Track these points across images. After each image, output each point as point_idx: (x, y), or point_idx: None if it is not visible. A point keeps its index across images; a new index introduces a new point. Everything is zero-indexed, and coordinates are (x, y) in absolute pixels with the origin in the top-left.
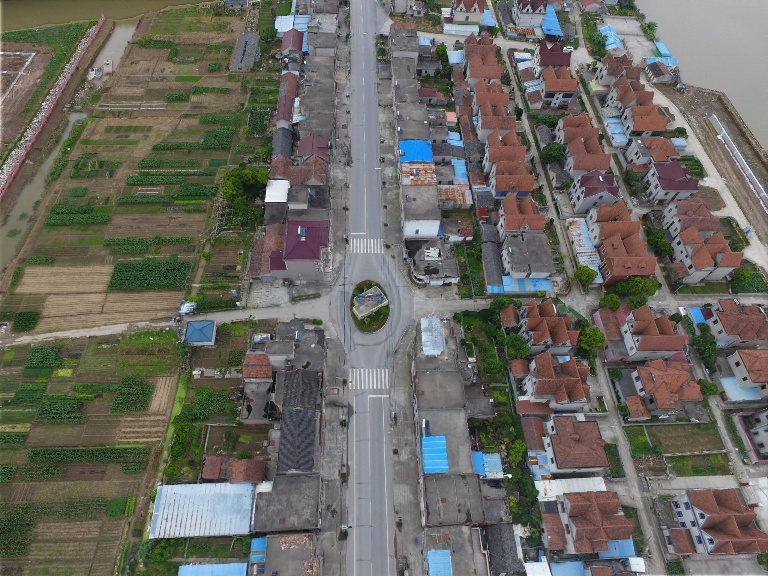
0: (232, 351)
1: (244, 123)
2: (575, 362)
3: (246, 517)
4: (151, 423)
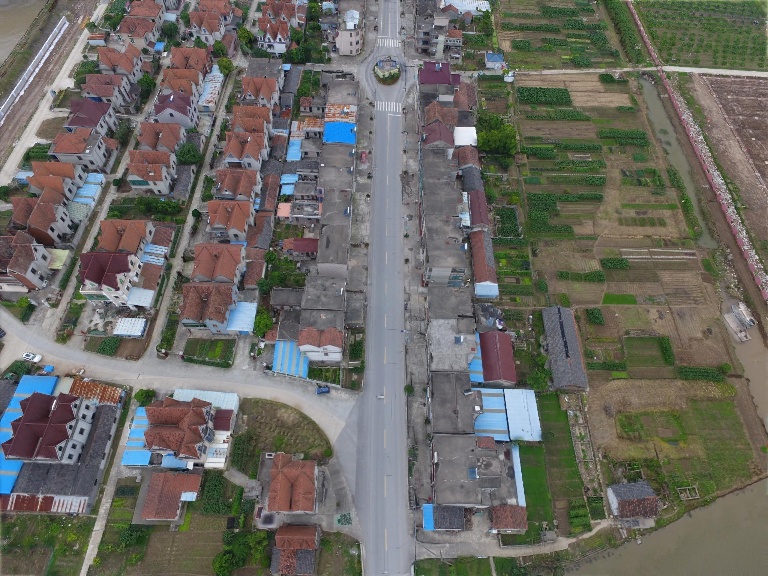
0: (473, 57)
1: (523, 224)
2: (269, 8)
3: (447, 1)
4: (506, 37)
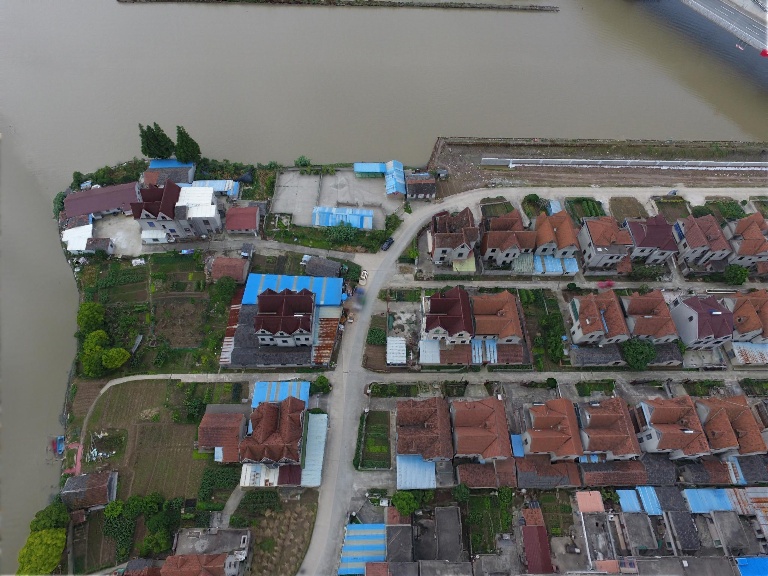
0: None
1: None
2: None
3: None
4: None
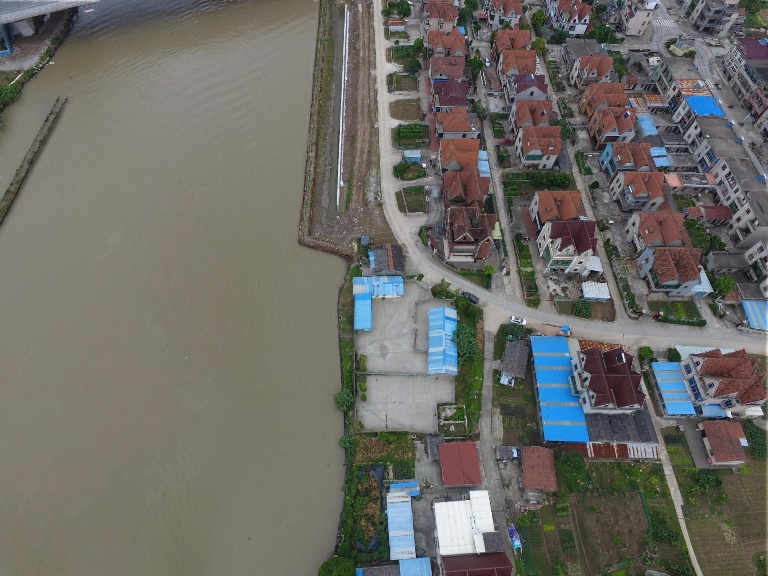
0: (751, 35)
1: None
2: None
3: None
4: None
